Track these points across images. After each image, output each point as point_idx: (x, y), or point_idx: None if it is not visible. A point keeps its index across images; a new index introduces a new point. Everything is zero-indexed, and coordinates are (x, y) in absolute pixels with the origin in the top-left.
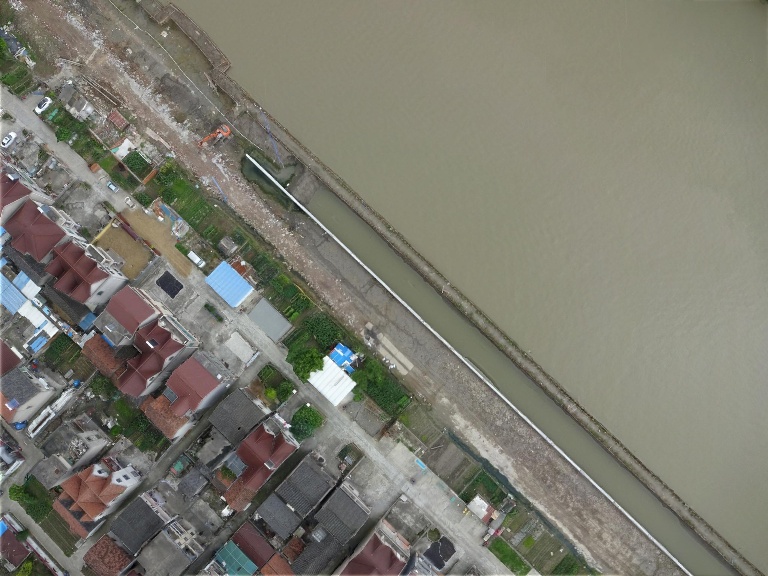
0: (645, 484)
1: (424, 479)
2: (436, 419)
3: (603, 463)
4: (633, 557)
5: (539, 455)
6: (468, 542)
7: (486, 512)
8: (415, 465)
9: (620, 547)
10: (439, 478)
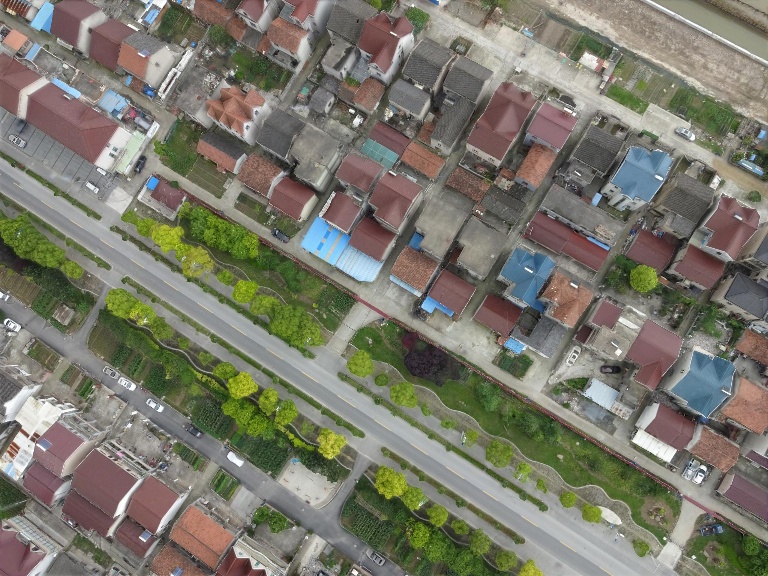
0: (737, 15)
1: (533, 51)
2: (531, 4)
3: (693, 12)
4: (740, 77)
5: (633, 13)
6: (586, 95)
7: (597, 64)
8: (522, 41)
9: (726, 72)
10: (546, 47)
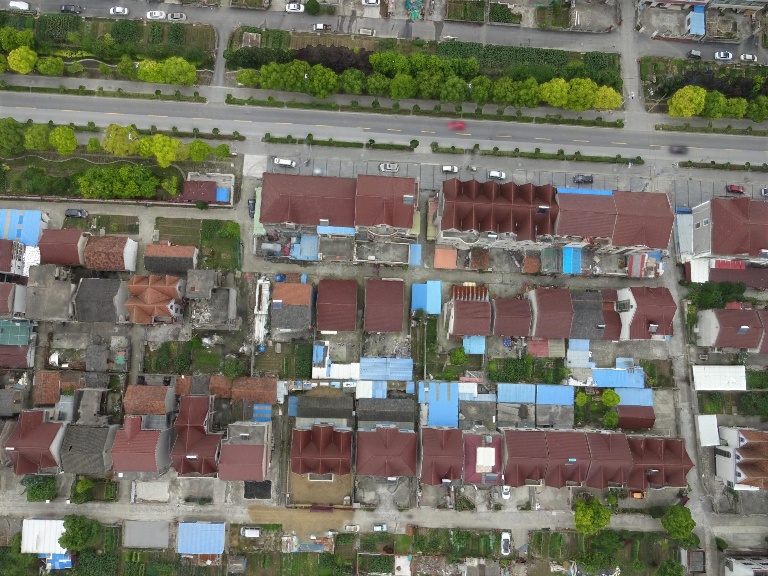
0: None
1: None
2: None
3: None
4: None
5: None
6: None
7: None
8: None
9: None
10: None
